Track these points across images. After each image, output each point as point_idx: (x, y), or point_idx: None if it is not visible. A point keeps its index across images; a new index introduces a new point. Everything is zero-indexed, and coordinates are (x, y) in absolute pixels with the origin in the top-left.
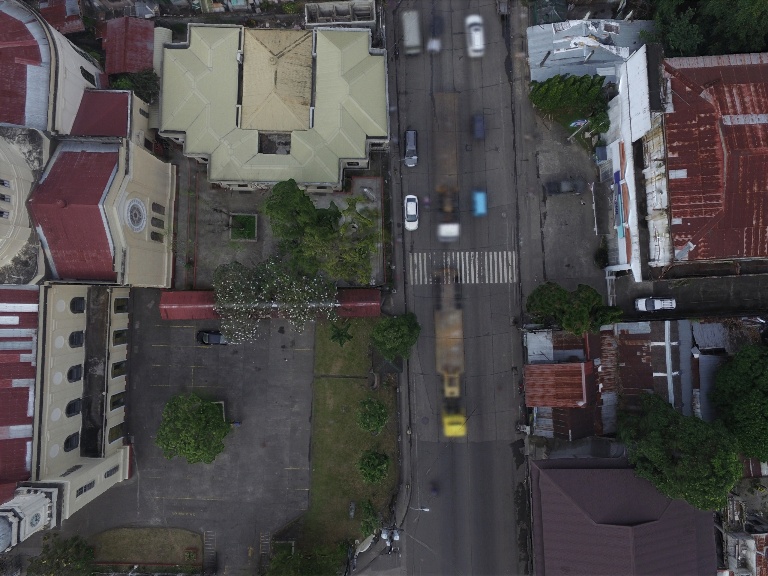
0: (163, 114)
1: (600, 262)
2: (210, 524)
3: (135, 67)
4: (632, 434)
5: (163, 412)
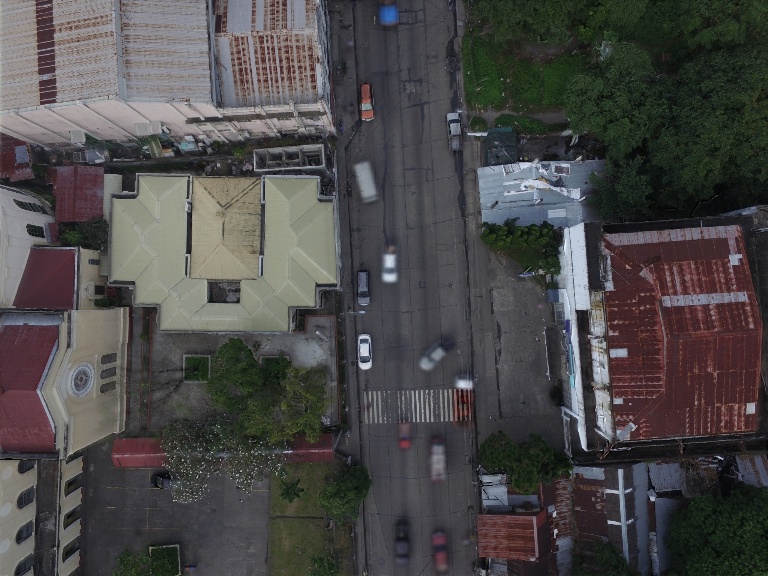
0: (112, 265)
1: (555, 400)
2: None
3: (84, 215)
4: None
5: (112, 574)
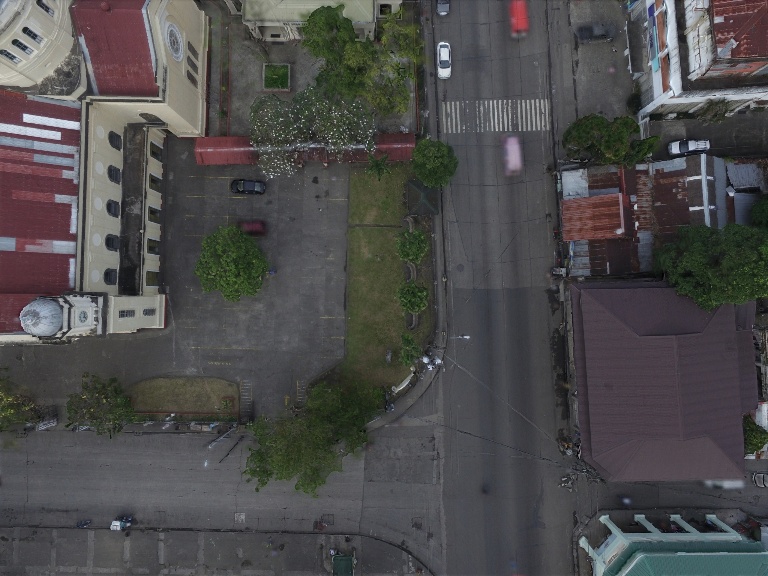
0: None
1: (633, 107)
2: (246, 373)
3: None
4: (672, 255)
5: (203, 241)
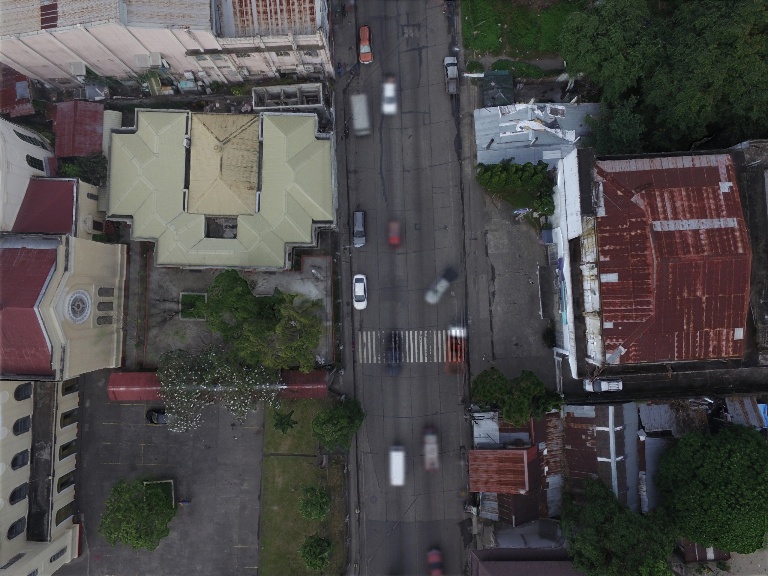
0: (110, 199)
1: (548, 342)
2: None
3: (84, 150)
4: (571, 526)
5: (106, 501)
